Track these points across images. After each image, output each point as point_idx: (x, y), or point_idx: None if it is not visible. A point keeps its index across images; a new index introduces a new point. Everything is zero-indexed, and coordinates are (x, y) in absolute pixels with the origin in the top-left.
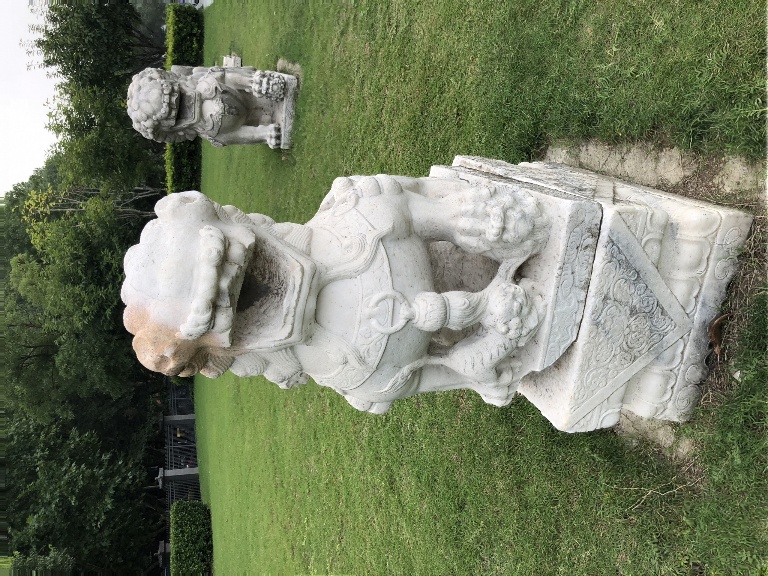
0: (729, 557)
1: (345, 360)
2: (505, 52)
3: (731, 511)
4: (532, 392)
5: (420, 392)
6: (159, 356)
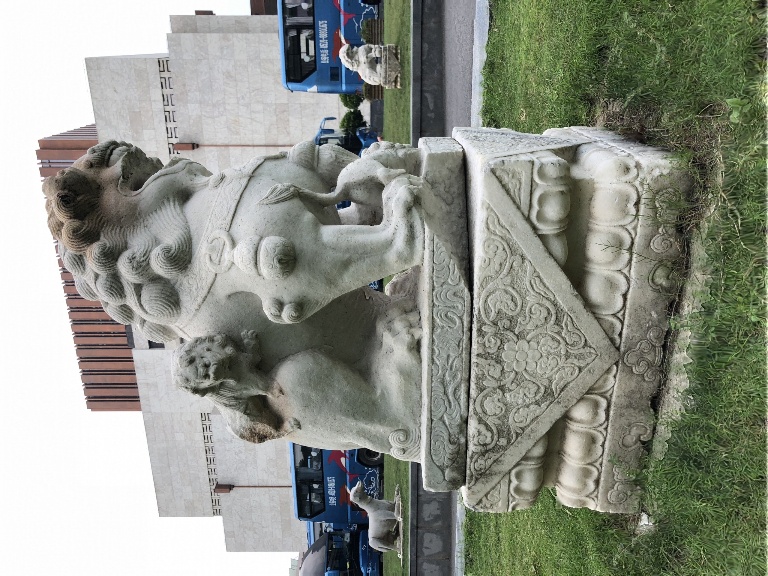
0: (737, 4)
1: (222, 174)
2: None
3: None
4: None
5: (330, 253)
6: (60, 175)
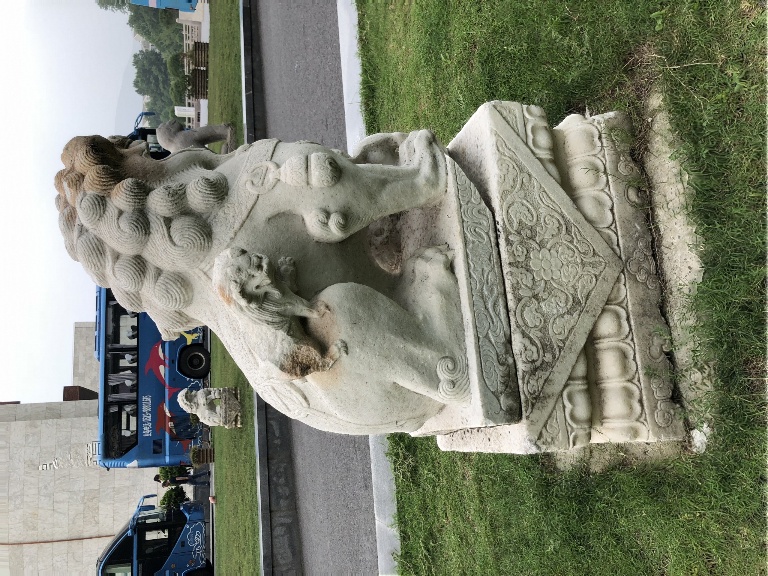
0: None
1: None
2: (514, 574)
3: (618, 8)
4: (485, 162)
5: (368, 173)
6: None
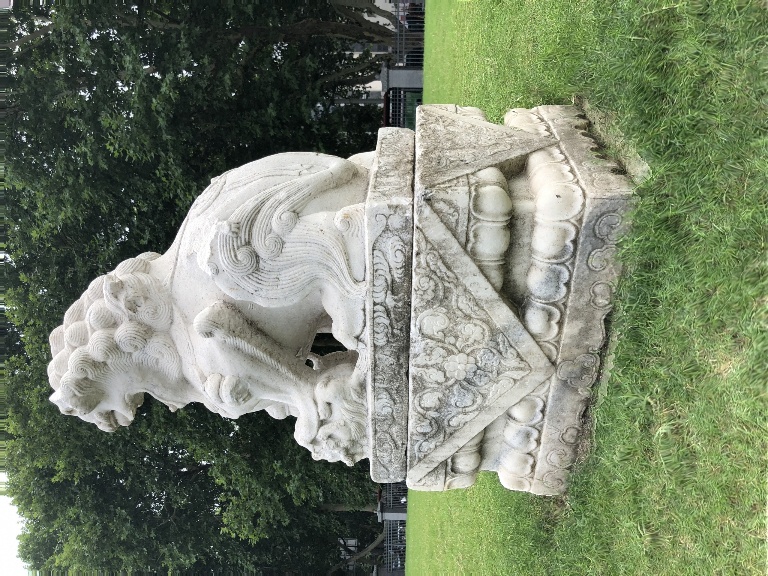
0: None
1: None
2: None
3: None
4: None
5: None
6: None
